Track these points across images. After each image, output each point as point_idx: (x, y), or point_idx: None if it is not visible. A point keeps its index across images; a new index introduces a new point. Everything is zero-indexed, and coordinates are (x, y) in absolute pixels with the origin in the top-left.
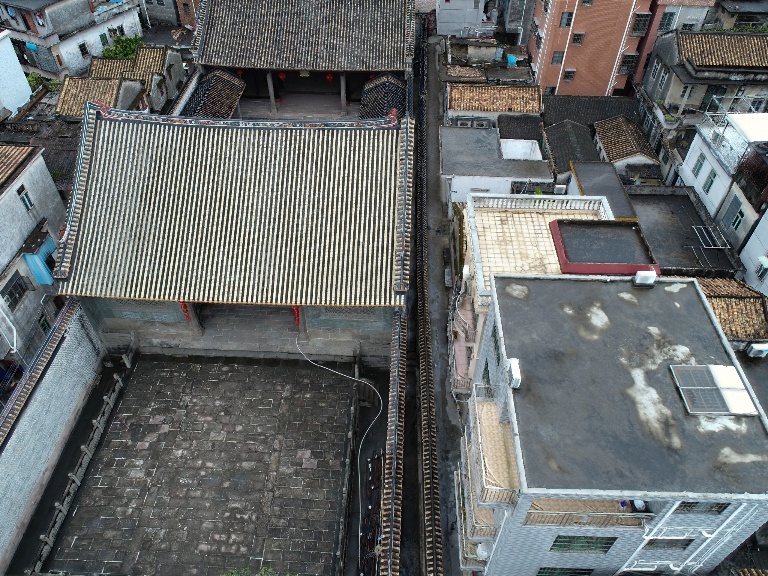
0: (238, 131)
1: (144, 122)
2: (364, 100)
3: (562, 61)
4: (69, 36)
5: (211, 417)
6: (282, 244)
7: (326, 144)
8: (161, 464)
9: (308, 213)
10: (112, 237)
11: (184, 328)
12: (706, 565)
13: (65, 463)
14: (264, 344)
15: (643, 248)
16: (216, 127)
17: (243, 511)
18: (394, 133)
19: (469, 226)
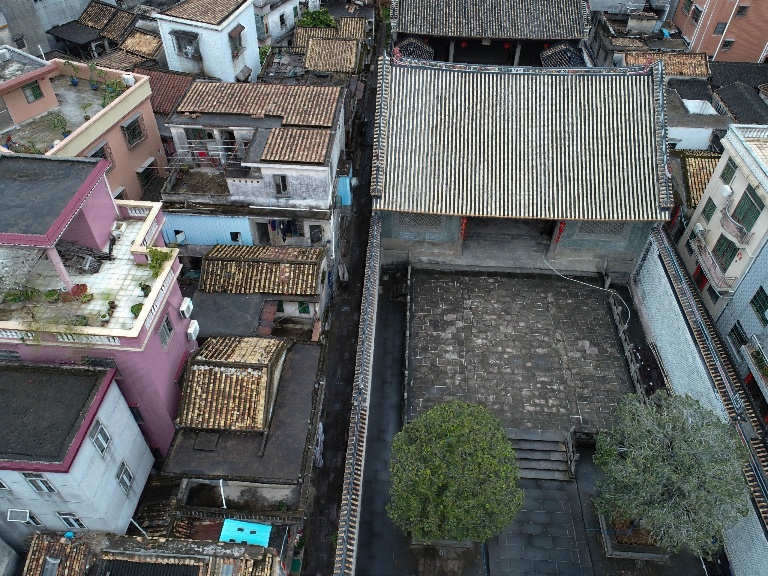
0: (509, 76)
1: (429, 68)
2: (547, 65)
3: (723, 32)
4: (276, 7)
5: (495, 316)
6: (557, 170)
7: (587, 87)
8: (468, 349)
9: (577, 144)
10: (412, 163)
11: (448, 248)
12: None
13: (380, 350)
14: (518, 262)
15: None
16: (490, 73)
17: (551, 383)
18: (645, 79)
19: (737, 150)
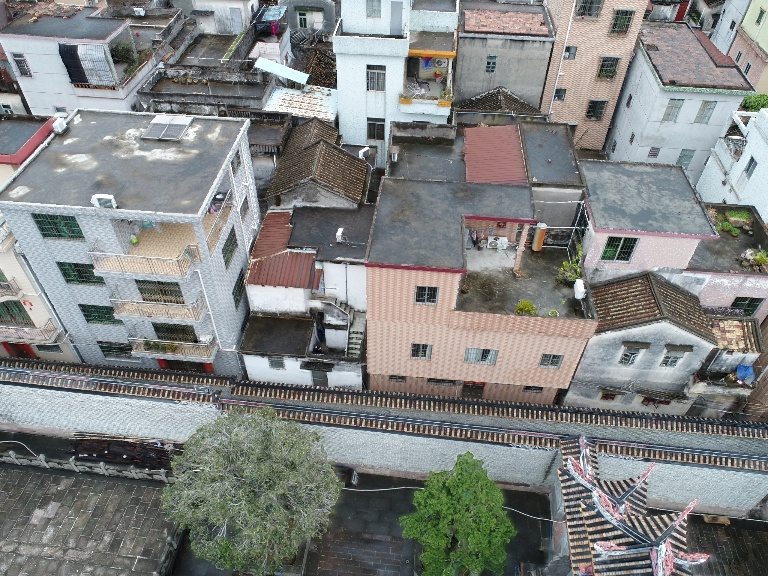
0: None
1: None
2: None
3: None
4: None
5: None
6: None
7: None
8: None
9: None
10: None
11: None
12: (258, 213)
13: None
14: None
15: (28, 120)
16: None
17: None
18: None
19: None
